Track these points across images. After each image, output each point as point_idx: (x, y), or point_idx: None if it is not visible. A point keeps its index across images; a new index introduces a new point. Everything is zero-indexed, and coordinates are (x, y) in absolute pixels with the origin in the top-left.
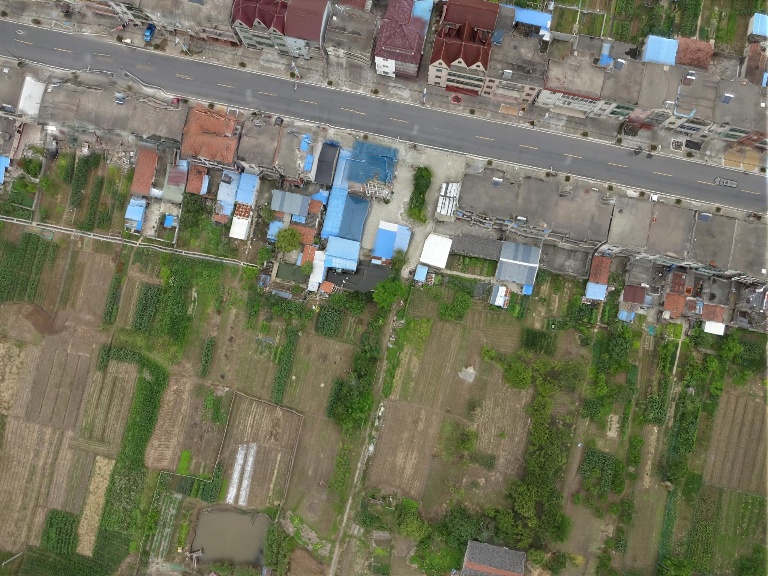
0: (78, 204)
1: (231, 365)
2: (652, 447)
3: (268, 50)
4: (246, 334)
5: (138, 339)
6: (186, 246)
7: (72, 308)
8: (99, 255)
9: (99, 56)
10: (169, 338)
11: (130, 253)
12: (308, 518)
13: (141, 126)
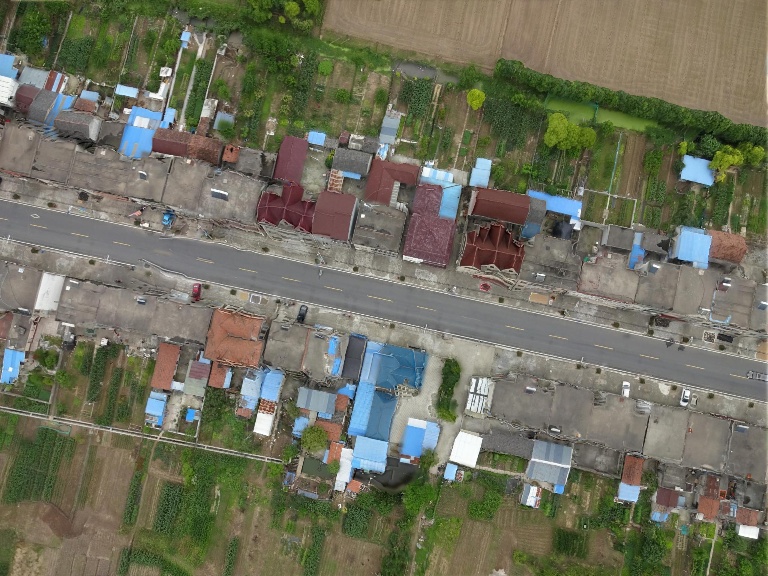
0: (96, 397)
1: (255, 565)
2: None
3: (294, 242)
4: (271, 533)
5: (159, 541)
6: (208, 440)
7: (91, 507)
8: (118, 450)
9: (118, 245)
10: (191, 538)
11: (150, 448)
12: None
13: (164, 327)
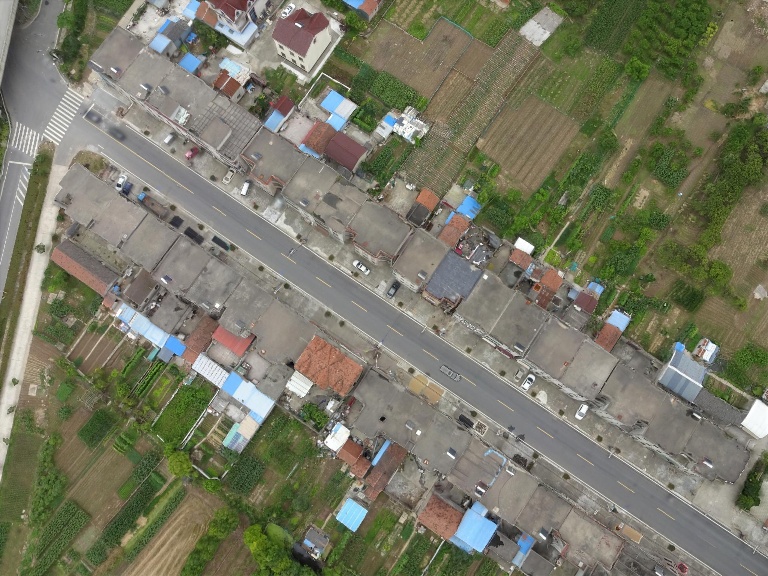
0: None
1: None
2: (614, 169)
3: None
4: None
5: None
6: None
7: None
8: None
9: None
10: None
11: None
12: None
13: None
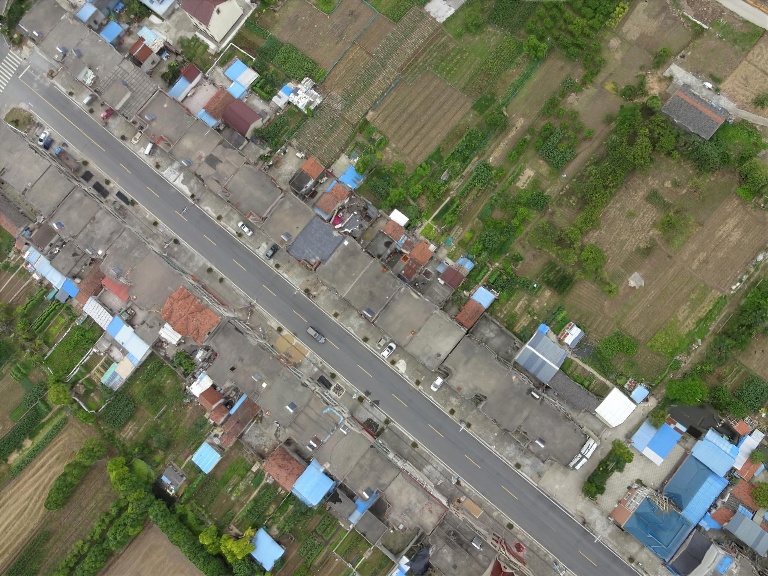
0: None
1: None
2: (501, 148)
3: None
4: None
5: None
6: None
7: None
8: None
9: None
10: None
11: None
12: None
13: None
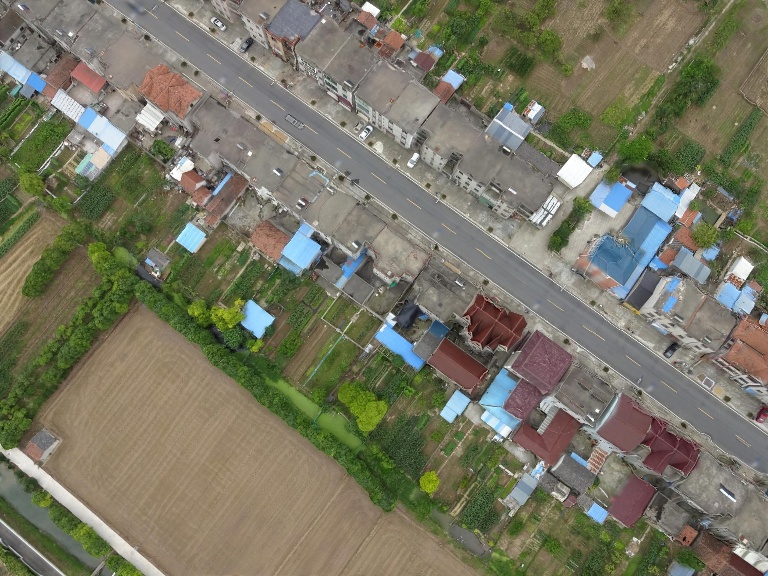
0: None
1: None
2: None
3: None
4: (765, 177)
5: None
6: None
7: None
8: None
9: None
10: None
11: None
12: (763, 12)
13: None
